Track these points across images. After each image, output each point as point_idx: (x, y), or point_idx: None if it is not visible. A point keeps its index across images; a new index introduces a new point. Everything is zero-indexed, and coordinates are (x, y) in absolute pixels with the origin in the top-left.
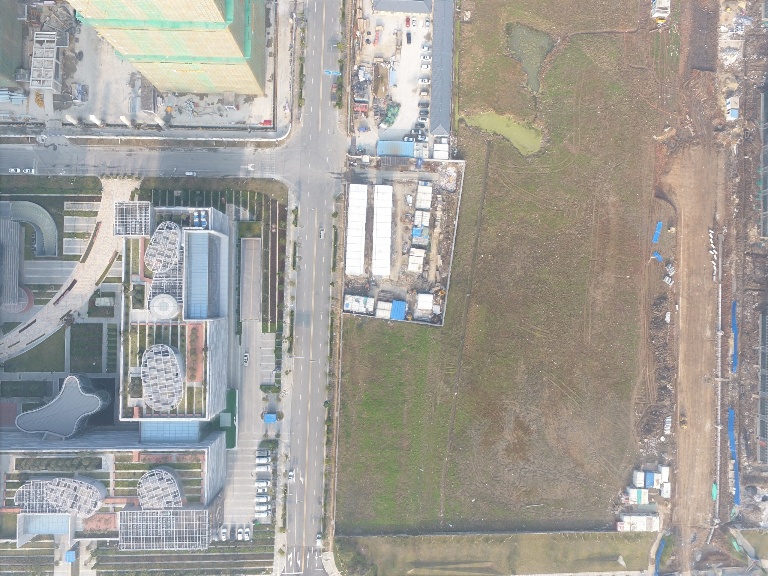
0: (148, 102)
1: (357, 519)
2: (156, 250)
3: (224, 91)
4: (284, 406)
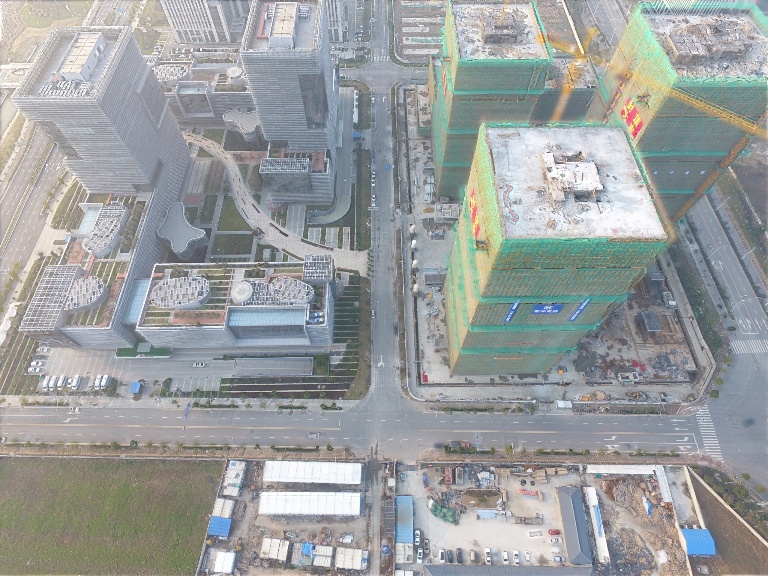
0: (432, 280)
1: (4, 481)
2: (290, 284)
3: (448, 338)
4: (146, 401)
